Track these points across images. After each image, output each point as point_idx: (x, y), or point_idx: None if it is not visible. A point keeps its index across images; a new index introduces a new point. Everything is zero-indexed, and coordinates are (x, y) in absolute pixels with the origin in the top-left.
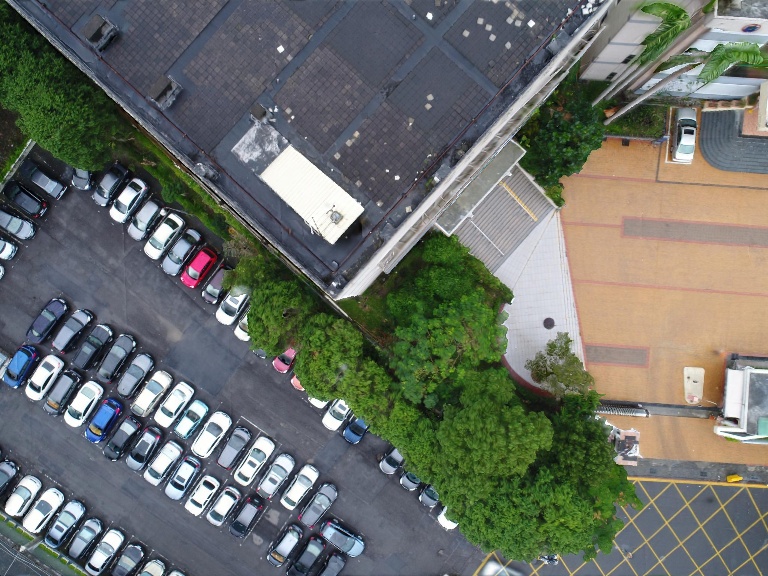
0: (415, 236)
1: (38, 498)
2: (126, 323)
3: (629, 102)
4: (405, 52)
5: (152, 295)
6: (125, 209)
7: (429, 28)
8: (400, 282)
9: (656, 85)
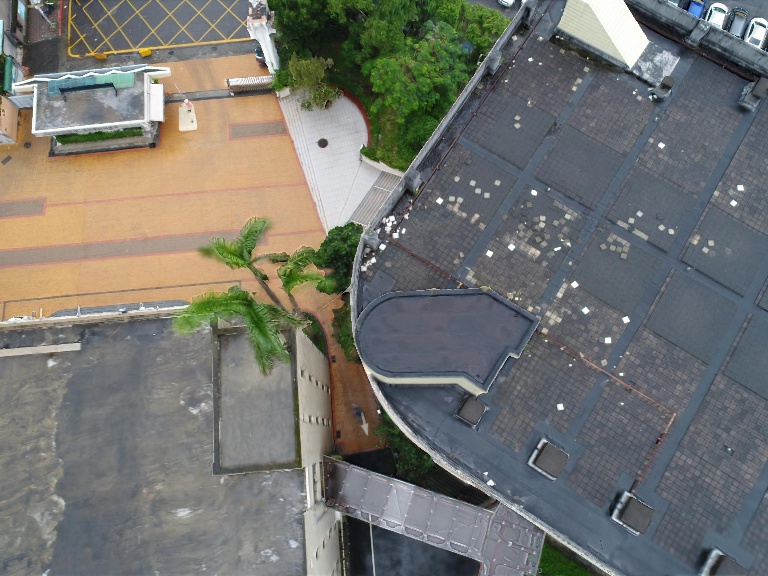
0: None
1: None
2: None
3: None
4: (549, 160)
5: None
6: None
7: (532, 184)
8: None
9: None
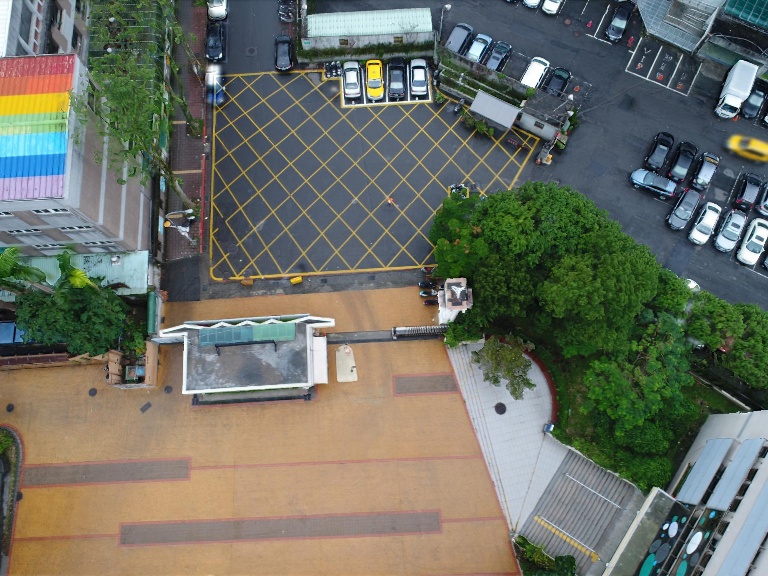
0: None
1: None
2: None
3: None
4: None
5: None
6: None
7: None
8: None
9: None
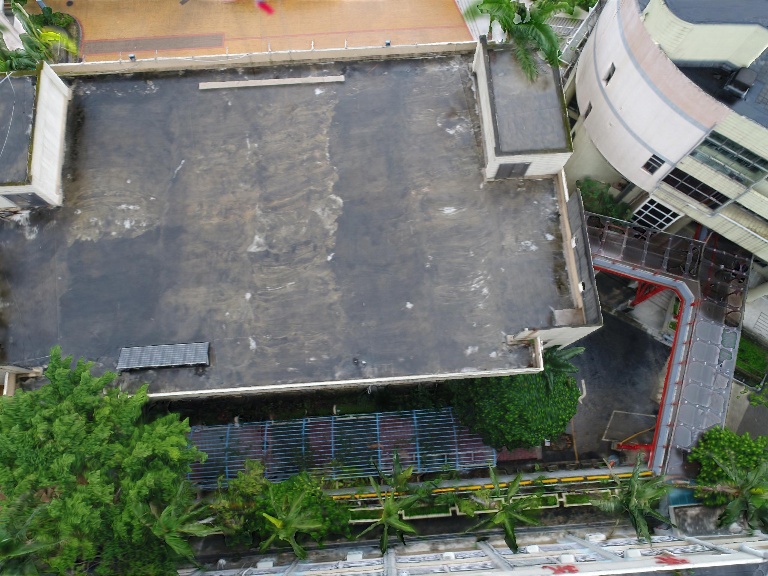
0: None
1: None
2: None
3: None
4: None
5: None
6: None
7: None
8: None
9: None
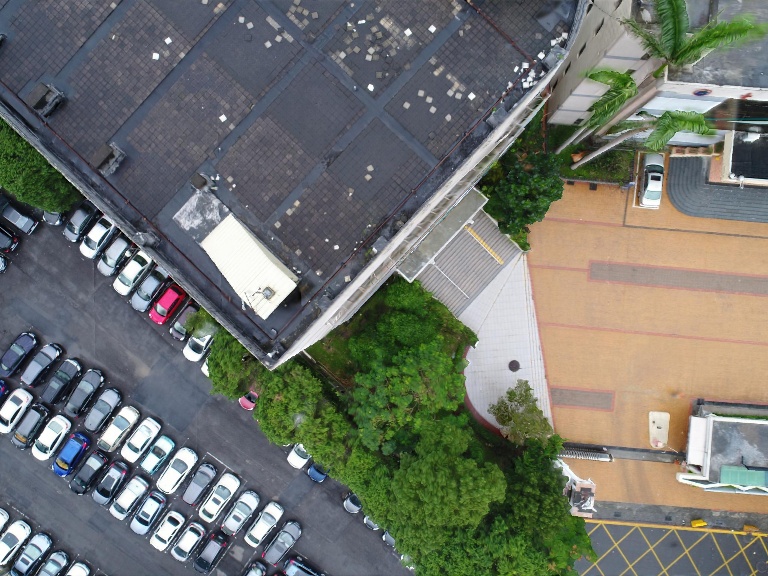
0: (363, 296)
1: (5, 530)
2: (95, 358)
3: (597, 147)
4: (346, 123)
5: (121, 330)
6: (95, 245)
7: (370, 99)
8: (362, 326)
9: (614, 140)
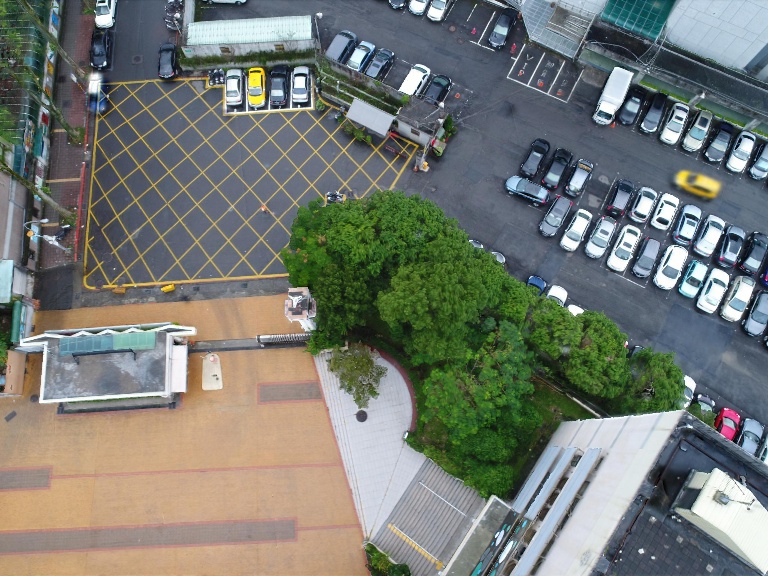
0: (577, 489)
1: None
2: None
3: None
4: None
5: (763, 396)
6: None
7: None
8: None
9: None
